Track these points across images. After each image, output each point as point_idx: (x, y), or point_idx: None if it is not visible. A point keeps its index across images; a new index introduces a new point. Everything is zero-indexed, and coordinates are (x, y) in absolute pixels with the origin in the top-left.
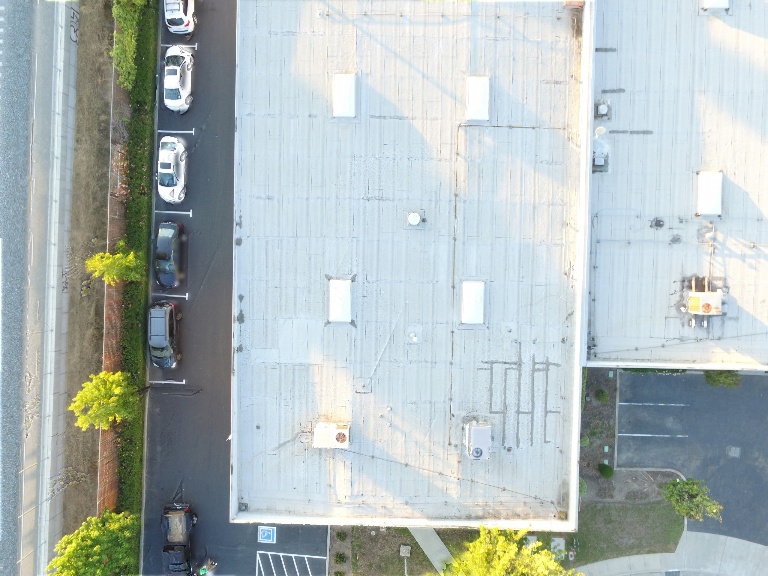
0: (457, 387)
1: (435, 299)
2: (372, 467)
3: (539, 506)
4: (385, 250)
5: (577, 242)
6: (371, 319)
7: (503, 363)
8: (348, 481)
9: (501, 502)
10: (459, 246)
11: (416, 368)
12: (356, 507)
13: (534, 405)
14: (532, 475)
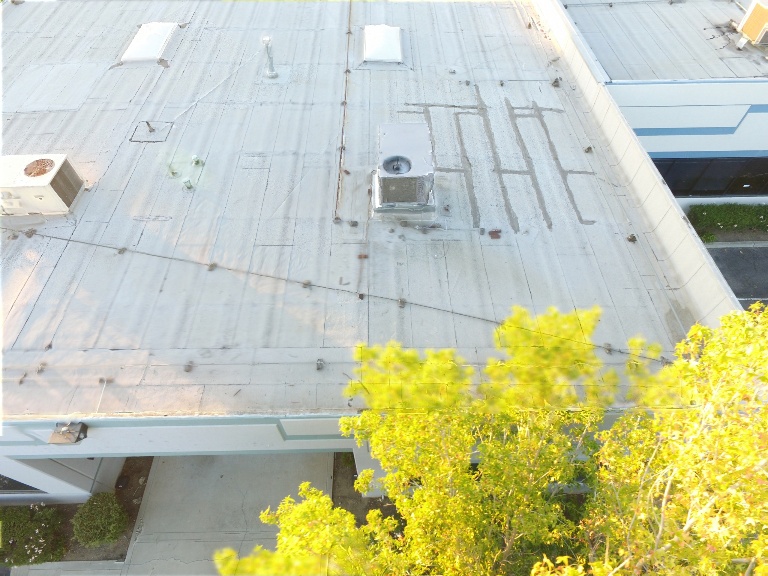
0: (356, 132)
1: (318, 43)
2: (112, 274)
3: (628, 372)
4: (243, 6)
5: (535, 6)
6: (199, 61)
7: (449, 106)
8: (22, 308)
9: (502, 359)
10: (358, 4)
11: (271, 111)
12: (10, 385)
13: (531, 161)
14: (575, 292)
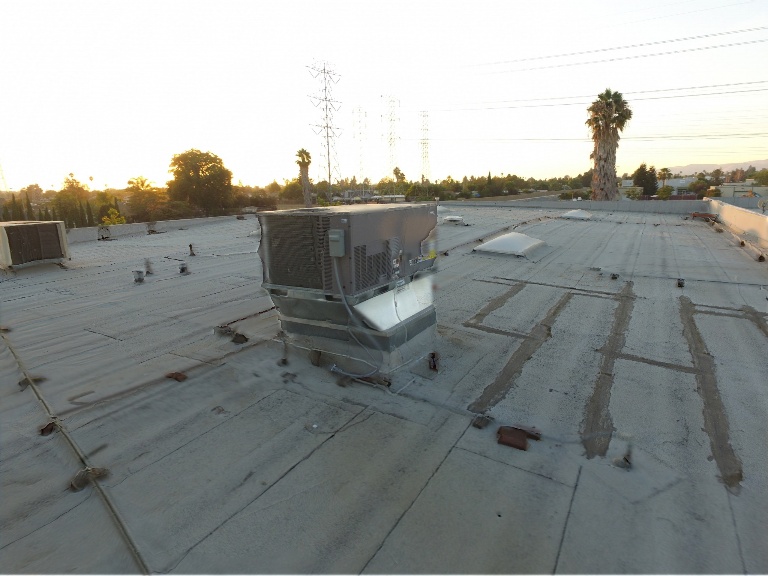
0: None
1: None
2: None
3: None
4: None
5: None
6: None
7: (563, 288)
8: None
9: None
10: None
11: None
12: None
13: (709, 359)
14: None
